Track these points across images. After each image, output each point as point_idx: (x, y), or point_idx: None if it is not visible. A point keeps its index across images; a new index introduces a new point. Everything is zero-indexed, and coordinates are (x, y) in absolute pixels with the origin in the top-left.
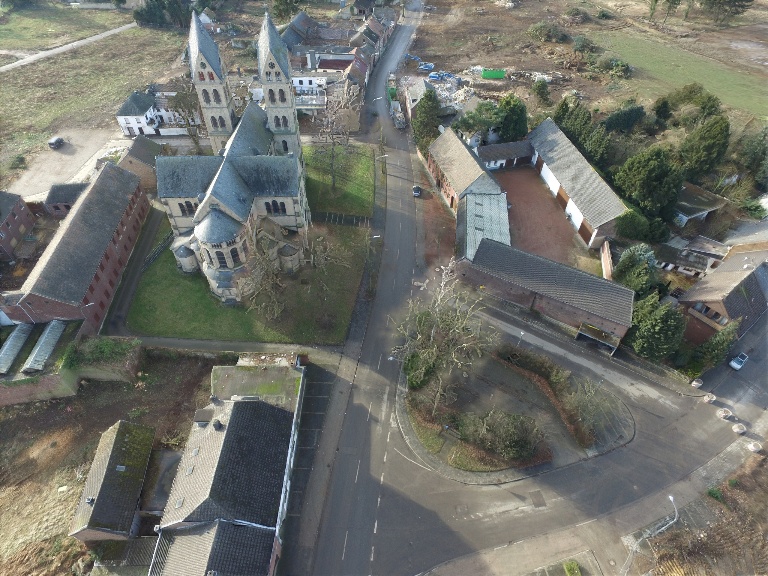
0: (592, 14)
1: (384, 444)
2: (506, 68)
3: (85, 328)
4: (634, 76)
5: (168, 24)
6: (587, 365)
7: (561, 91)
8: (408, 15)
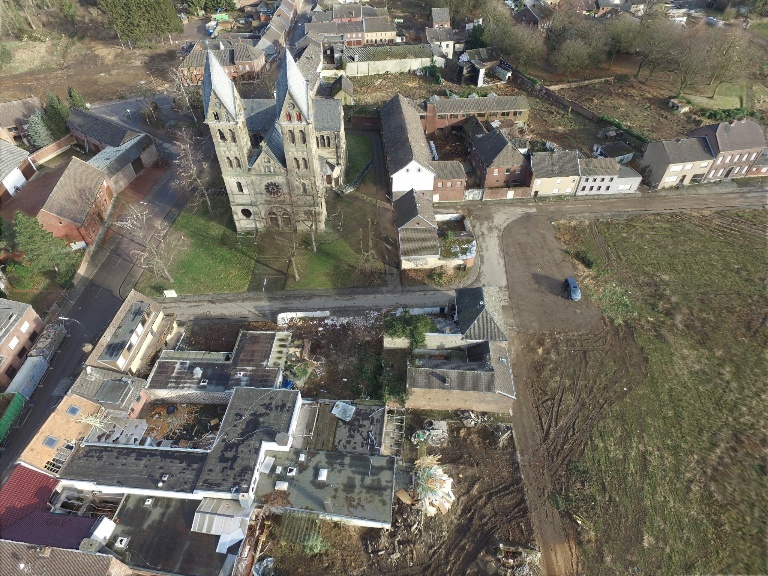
0: None
1: None
2: None
3: None
4: None
5: None
6: None
7: None
8: None
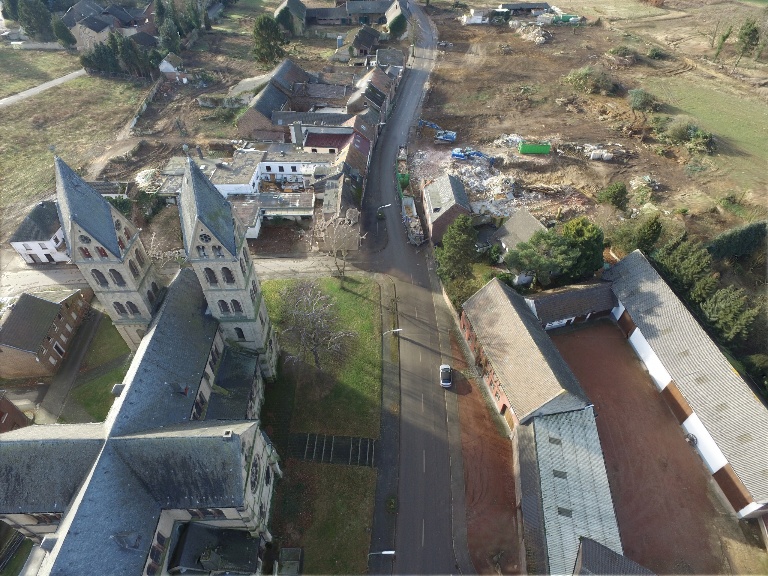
0: (641, 52)
1: None
2: (549, 136)
3: None
4: (719, 150)
5: (123, 72)
6: None
7: (627, 175)
8: (419, 54)
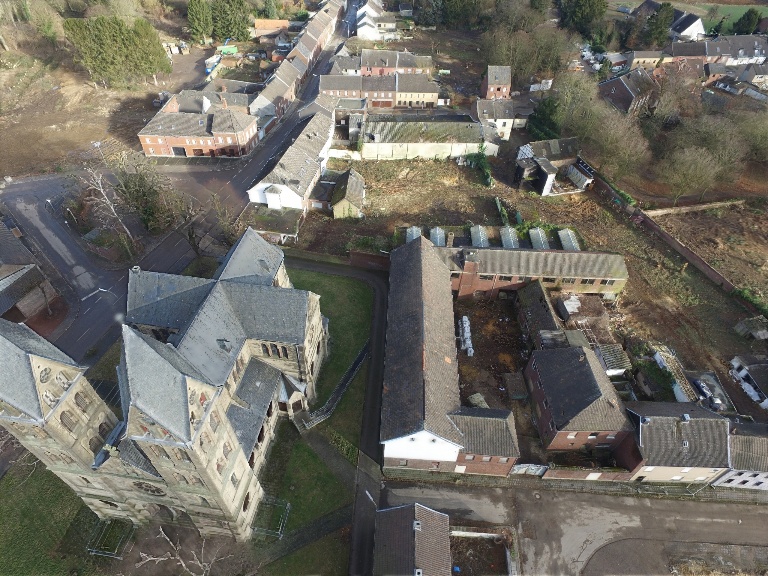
0: None
1: (205, 205)
2: None
3: None
4: None
5: None
6: (38, 221)
7: None
8: None
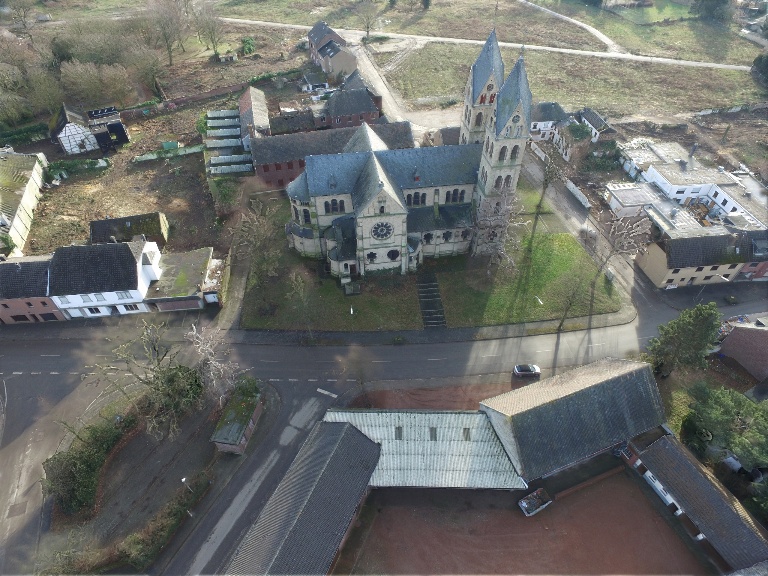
0: None
1: None
2: None
3: (252, 180)
4: None
5: None
6: None
7: None
8: None
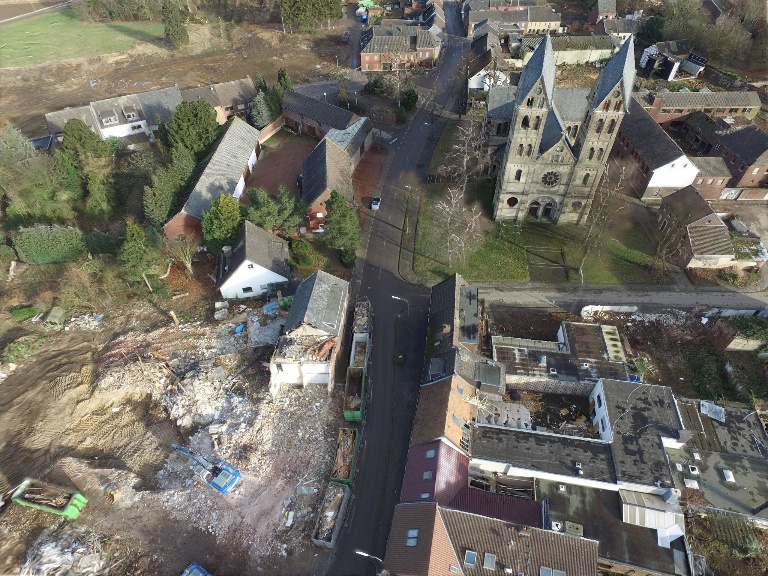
0: None
1: None
2: None
3: None
4: None
5: None
6: None
7: None
8: None
